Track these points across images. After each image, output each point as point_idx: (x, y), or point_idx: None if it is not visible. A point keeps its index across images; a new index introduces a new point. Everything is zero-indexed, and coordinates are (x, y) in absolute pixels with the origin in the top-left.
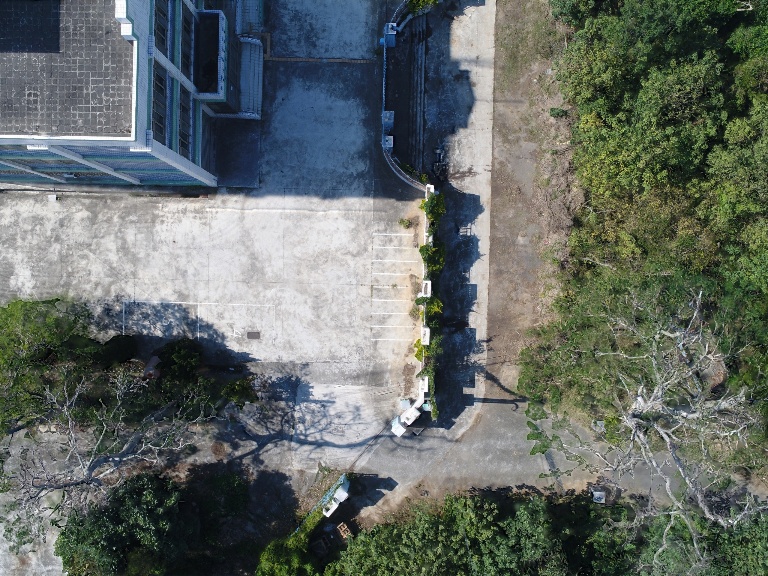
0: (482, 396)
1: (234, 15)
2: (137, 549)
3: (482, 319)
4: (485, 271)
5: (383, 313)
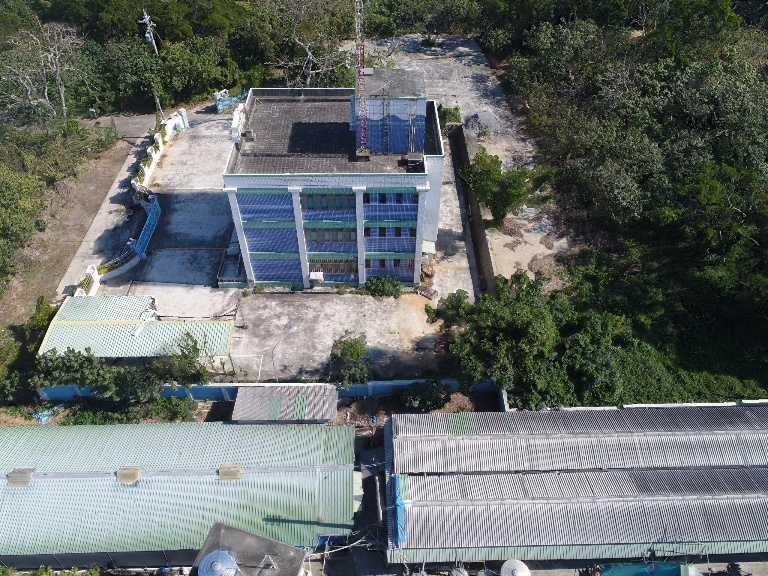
0: (139, 138)
1: (243, 264)
2: (301, 55)
3: (128, 161)
4: (119, 177)
5: (182, 156)
